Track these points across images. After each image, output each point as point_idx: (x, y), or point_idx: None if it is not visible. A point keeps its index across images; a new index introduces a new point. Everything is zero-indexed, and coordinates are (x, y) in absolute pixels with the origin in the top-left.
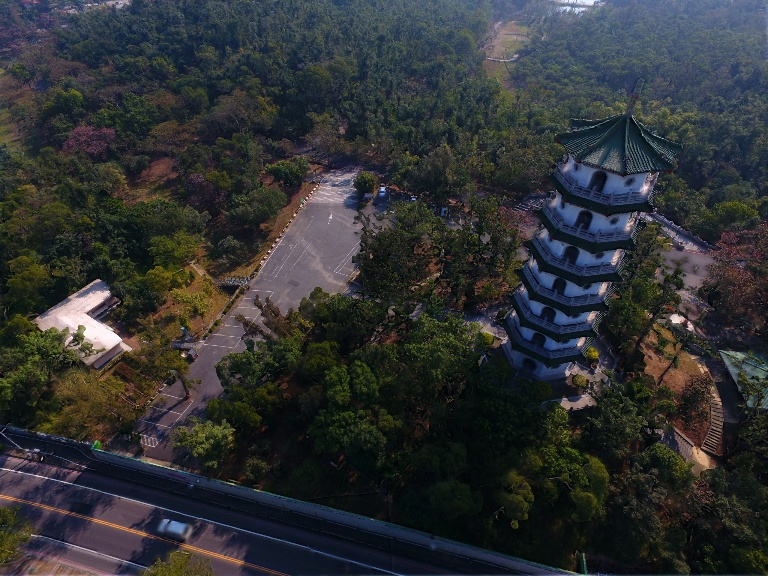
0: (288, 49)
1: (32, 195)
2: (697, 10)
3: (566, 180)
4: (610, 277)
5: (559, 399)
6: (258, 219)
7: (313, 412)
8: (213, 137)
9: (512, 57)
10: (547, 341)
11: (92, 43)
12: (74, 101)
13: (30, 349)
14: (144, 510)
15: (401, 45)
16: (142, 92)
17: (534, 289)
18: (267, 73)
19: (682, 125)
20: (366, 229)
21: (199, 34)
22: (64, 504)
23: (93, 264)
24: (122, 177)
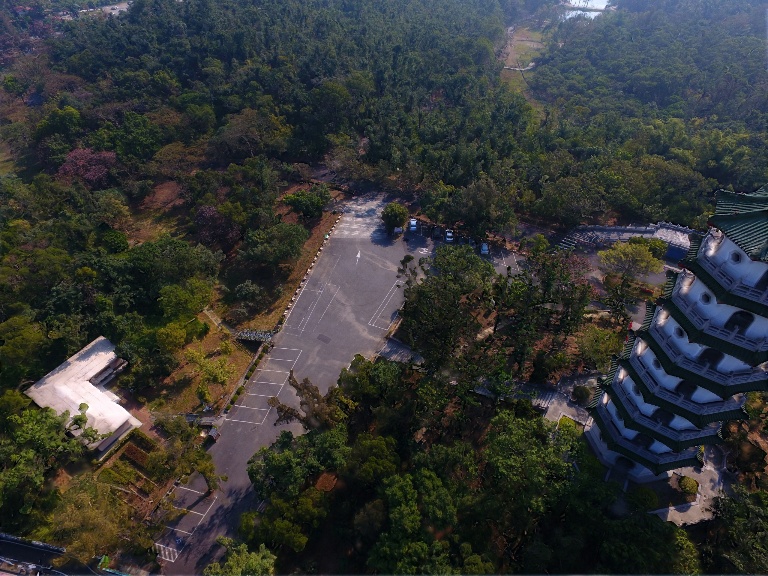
0: (300, 62)
1: (25, 233)
2: (719, 16)
3: (721, 273)
4: (760, 385)
5: (665, 508)
6: (278, 259)
7: (372, 535)
8: (222, 159)
9: (528, 65)
10: (656, 444)
11: (89, 54)
12: (70, 119)
13: (23, 438)
14: None
15: (417, 55)
16: (144, 109)
17: (650, 389)
18: (278, 88)
19: (736, 148)
20: (412, 284)
21: (204, 46)
22: None
23: (95, 321)
24: (125, 208)
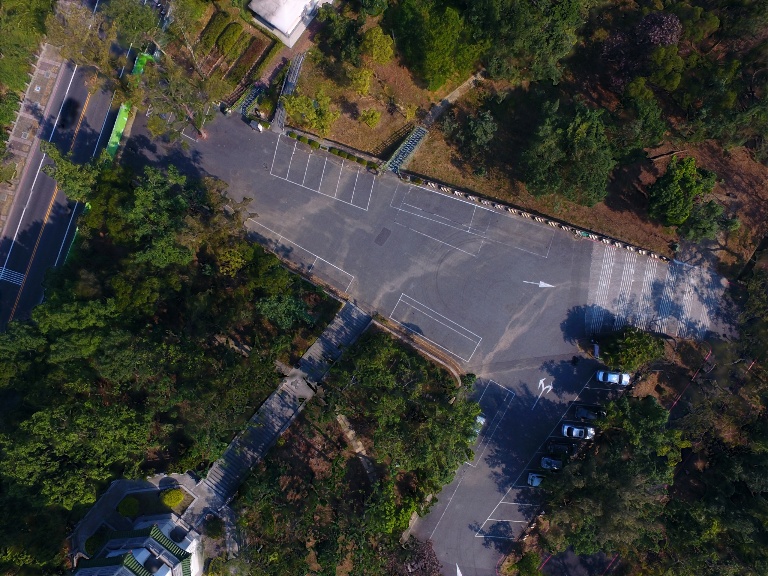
0: None
1: None
2: None
3: None
4: None
5: None
6: None
7: None
8: None
9: None
10: None
11: None
12: None
13: None
14: (98, 123)
15: None
16: None
17: None
18: None
19: None
20: None
21: None
22: (112, 47)
23: None
24: None
